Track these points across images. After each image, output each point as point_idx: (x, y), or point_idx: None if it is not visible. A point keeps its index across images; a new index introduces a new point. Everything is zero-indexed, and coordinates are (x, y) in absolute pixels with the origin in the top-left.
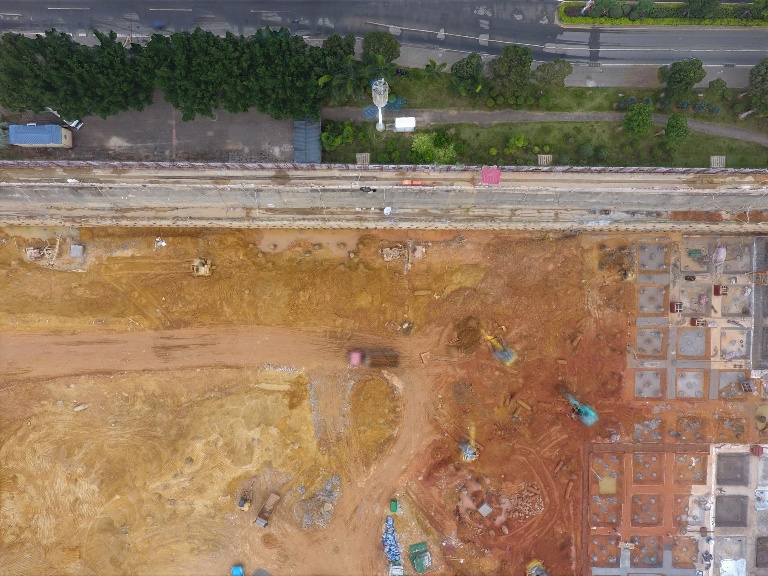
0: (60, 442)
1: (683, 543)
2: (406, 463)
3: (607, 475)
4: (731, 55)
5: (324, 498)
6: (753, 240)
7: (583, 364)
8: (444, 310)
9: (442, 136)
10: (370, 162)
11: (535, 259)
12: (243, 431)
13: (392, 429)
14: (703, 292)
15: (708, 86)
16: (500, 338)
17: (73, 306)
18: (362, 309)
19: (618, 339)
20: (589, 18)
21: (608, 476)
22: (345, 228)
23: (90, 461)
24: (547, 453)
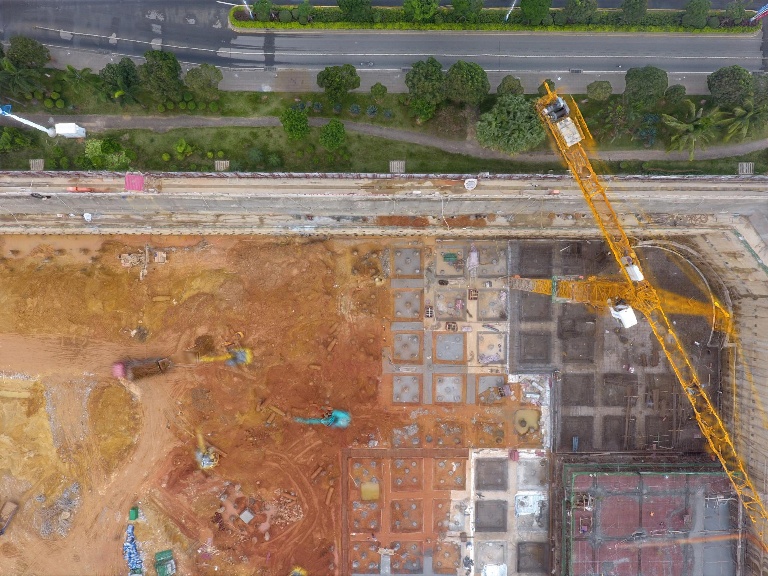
0: None
1: (445, 548)
2: (147, 470)
3: (367, 481)
4: (408, 59)
5: (62, 506)
6: (507, 244)
7: (338, 369)
8: (180, 316)
9: (107, 142)
10: (44, 168)
11: (278, 264)
12: None
13: (132, 436)
14: (459, 296)
15: None
16: (237, 344)
17: None
18: (96, 315)
19: (375, 344)
20: (258, 22)
21: (371, 482)
22: None
23: None
24: (301, 459)
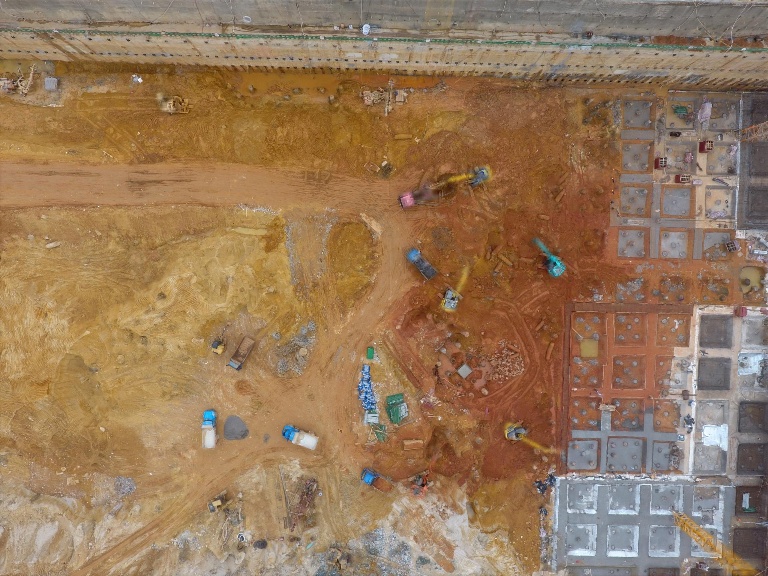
0: (31, 279)
1: (665, 407)
2: (384, 310)
3: (589, 336)
4: None
5: (299, 343)
6: (739, 97)
7: (566, 221)
8: (424, 153)
9: None
10: None
11: (518, 106)
12: (217, 269)
13: (370, 275)
14: (688, 150)
15: None
16: (481, 182)
17: (46, 138)
18: (341, 150)
19: (602, 197)
20: None
21: (590, 339)
22: (325, 69)
23: (61, 298)
24: (528, 309)
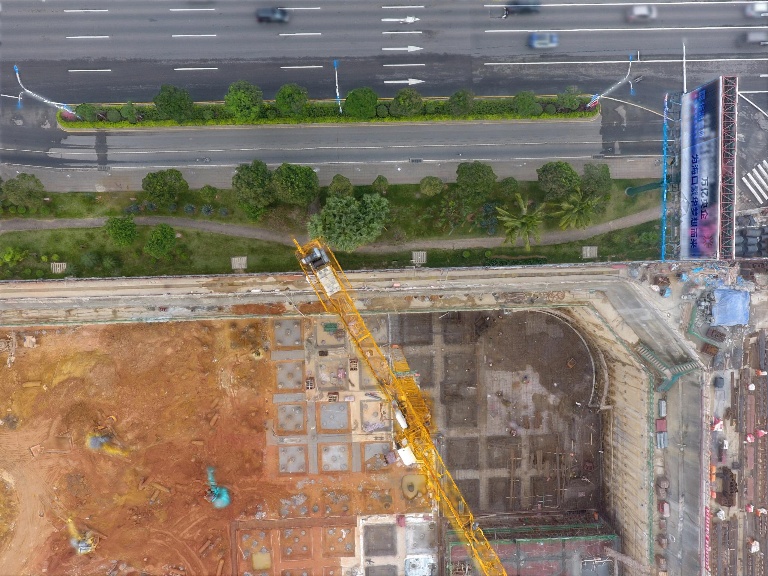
0: None
1: None
2: (26, 557)
3: (257, 551)
4: (245, 154)
5: None
6: None
7: (222, 443)
8: (50, 402)
9: None
10: None
11: (151, 344)
12: None
13: (8, 523)
14: (341, 366)
15: (223, 187)
16: (110, 428)
17: None
18: None
19: (258, 416)
20: (86, 123)
21: None
22: None
23: None
24: (187, 535)
